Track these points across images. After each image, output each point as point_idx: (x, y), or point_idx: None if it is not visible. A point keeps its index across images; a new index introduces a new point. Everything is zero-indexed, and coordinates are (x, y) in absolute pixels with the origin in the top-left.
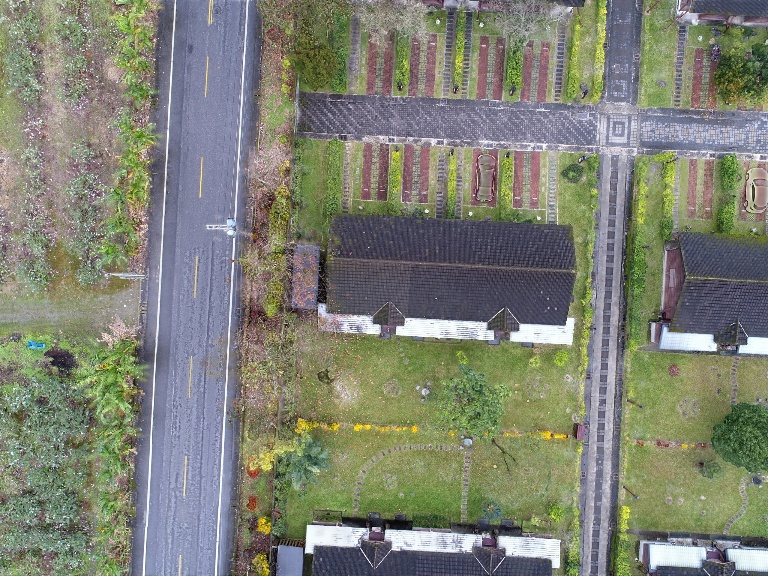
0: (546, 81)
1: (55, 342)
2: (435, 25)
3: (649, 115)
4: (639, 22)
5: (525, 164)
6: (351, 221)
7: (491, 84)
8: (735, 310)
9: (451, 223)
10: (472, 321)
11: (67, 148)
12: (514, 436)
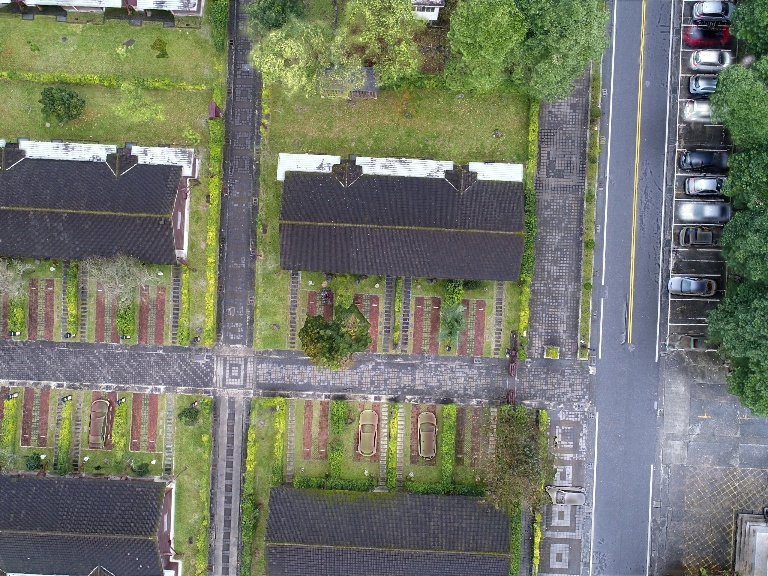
0: (163, 324)
1: None
2: (51, 271)
3: (265, 357)
4: (253, 265)
5: (143, 406)
6: None
7: (109, 327)
8: (322, 568)
9: (45, 482)
10: (73, 575)
11: None
12: None
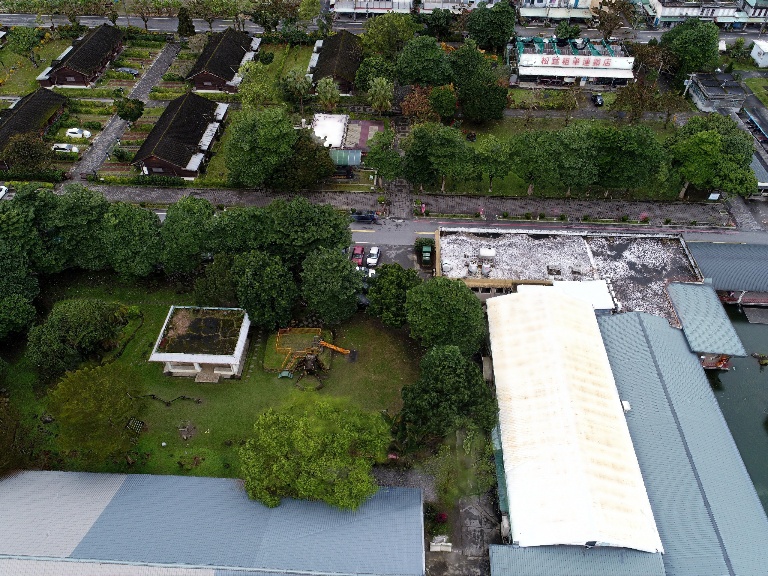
0: None
1: (116, 5)
2: None
3: None
4: None
5: (129, 83)
6: (120, 34)
7: None
8: None
9: None
10: None
11: (184, 5)
12: (6, 79)
